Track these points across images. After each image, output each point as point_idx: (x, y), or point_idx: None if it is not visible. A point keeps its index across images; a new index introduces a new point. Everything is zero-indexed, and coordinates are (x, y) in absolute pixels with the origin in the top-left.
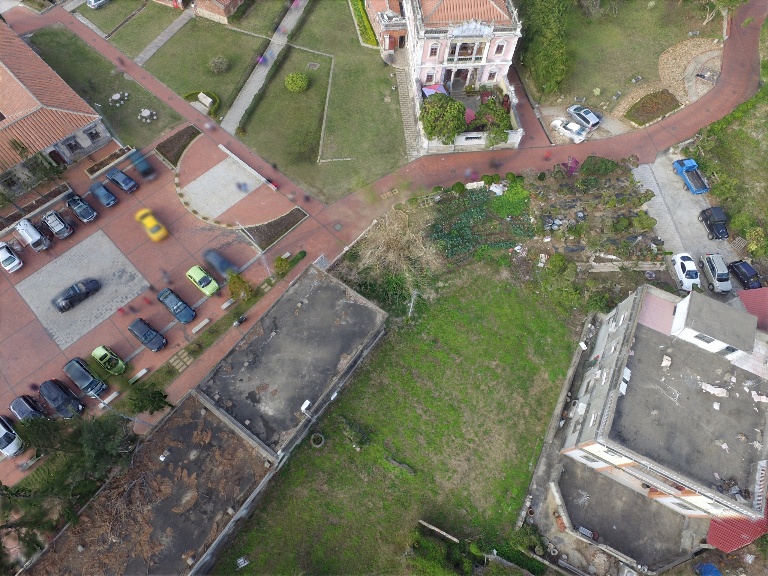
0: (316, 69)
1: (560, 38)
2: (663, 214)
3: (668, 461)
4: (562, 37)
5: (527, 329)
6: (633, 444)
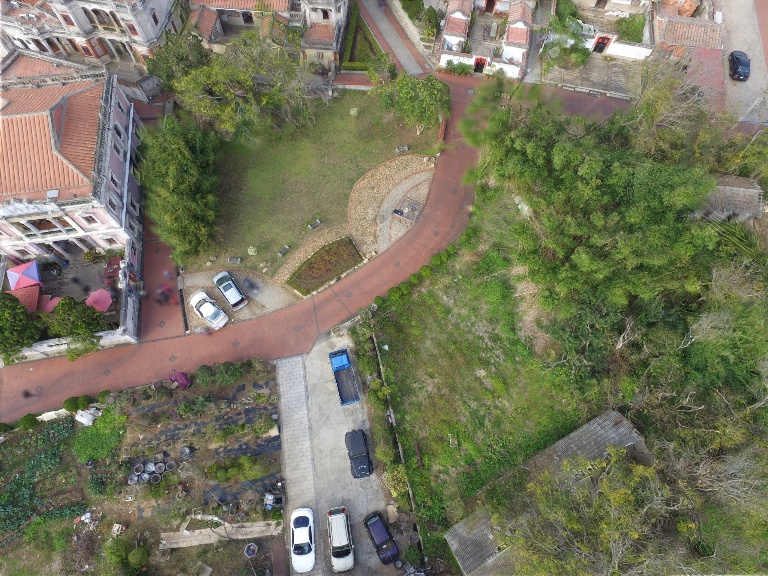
0: None
1: (174, 197)
2: (301, 437)
3: None
4: (178, 195)
5: None
6: None
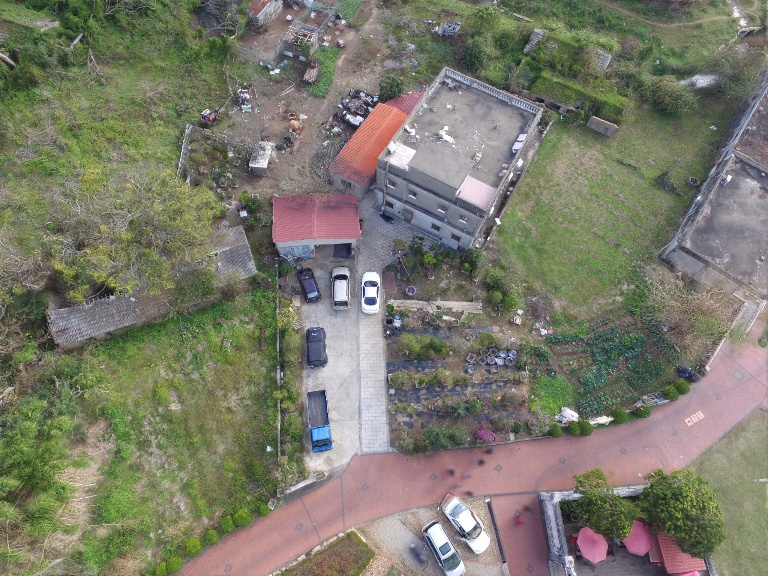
0: None
1: None
2: (368, 370)
3: (492, 102)
4: None
5: (537, 250)
6: (515, 112)
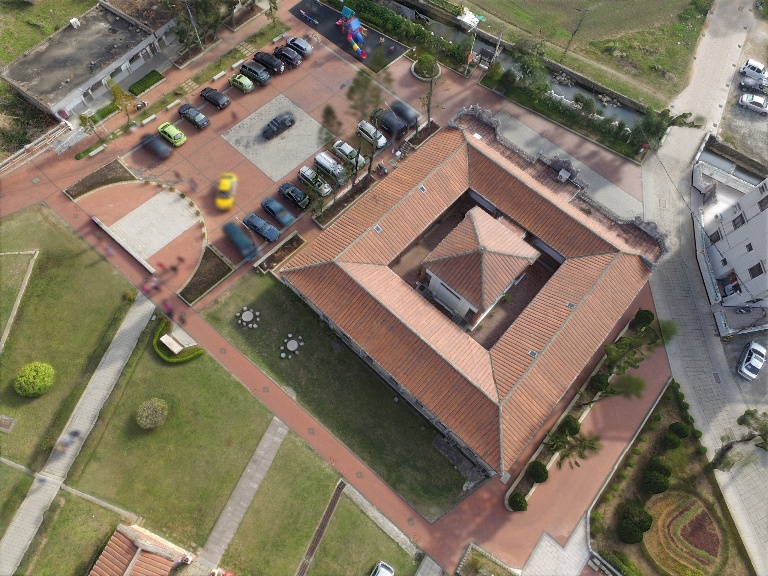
0: (2, 416)
1: None
2: None
3: None
4: None
5: None
6: None
